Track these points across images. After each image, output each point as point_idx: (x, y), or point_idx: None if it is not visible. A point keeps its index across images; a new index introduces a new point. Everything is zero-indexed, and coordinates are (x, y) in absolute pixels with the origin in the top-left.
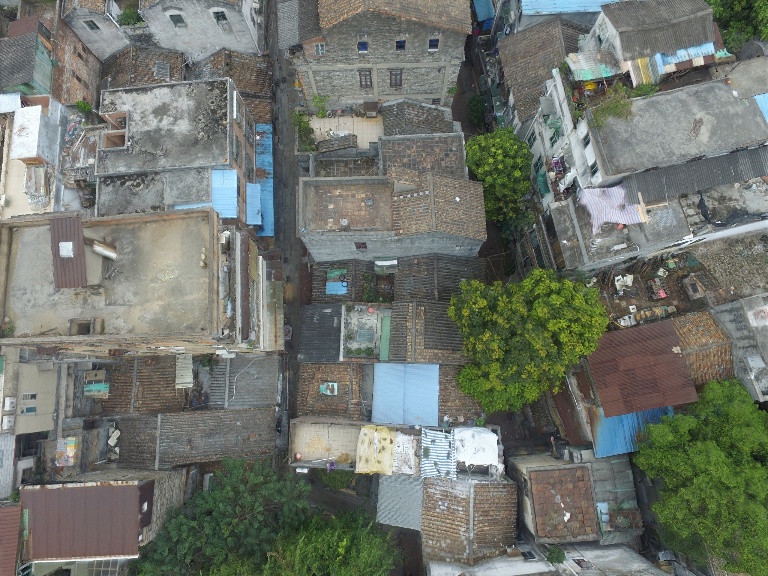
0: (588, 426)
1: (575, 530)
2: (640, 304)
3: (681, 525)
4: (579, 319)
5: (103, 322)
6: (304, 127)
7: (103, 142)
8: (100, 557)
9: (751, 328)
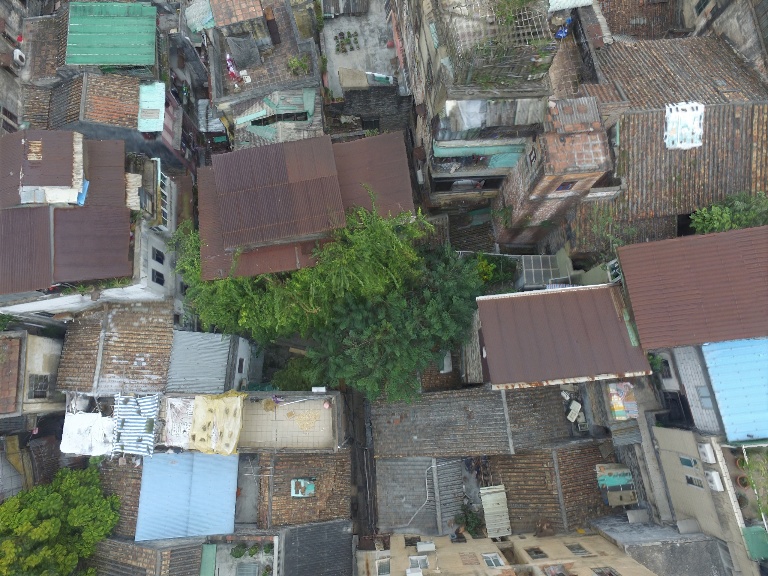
0: None
1: None
2: None
3: None
4: None
5: None
6: None
7: None
8: (524, 295)
9: None
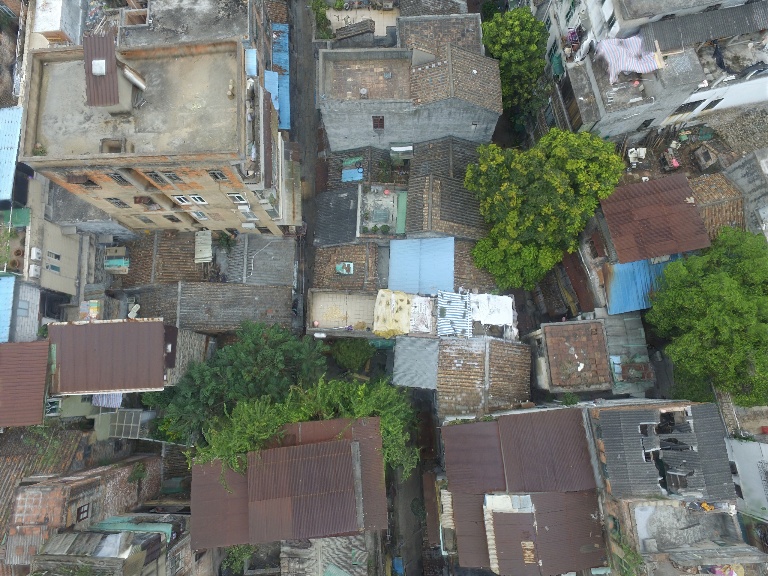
0: (601, 292)
1: (588, 379)
2: (653, 176)
3: (693, 362)
4: (596, 158)
5: (133, 147)
6: (322, 15)
7: (125, 20)
8: (126, 390)
9: (763, 176)
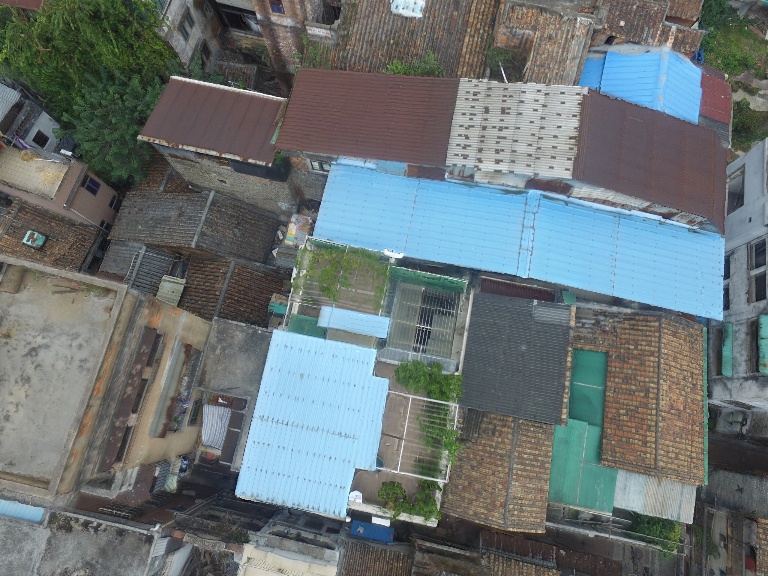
0: None
1: None
2: None
3: None
4: None
5: None
6: None
7: None
8: (211, 86)
9: None
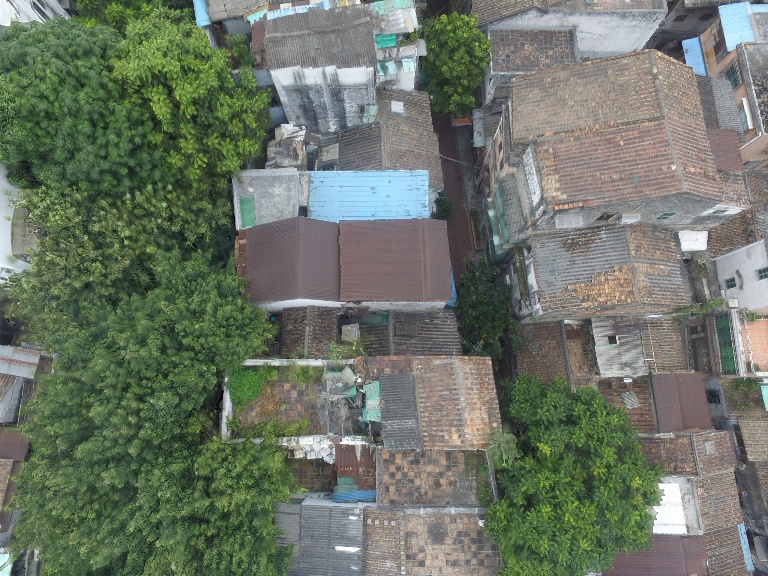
0: None
1: None
2: None
3: None
4: None
5: None
6: None
7: None
8: None
9: None
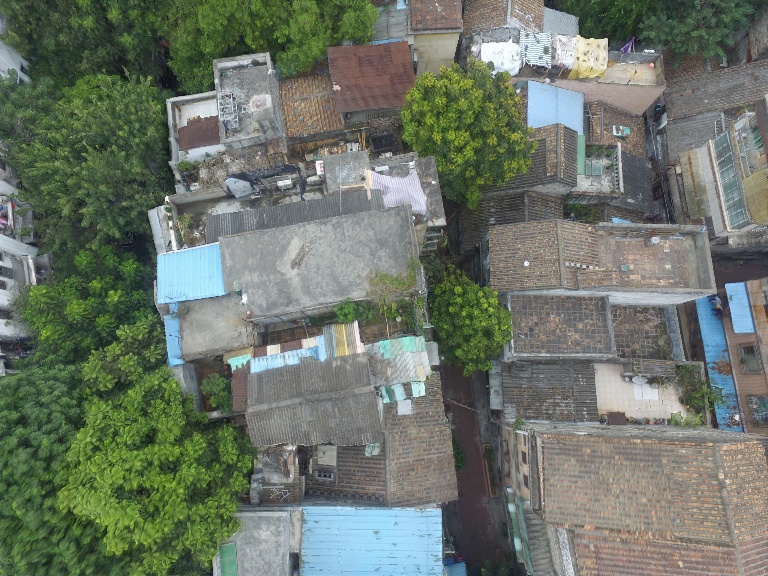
0: None
1: None
2: None
3: None
4: (444, 86)
5: None
6: None
7: None
8: None
9: None
